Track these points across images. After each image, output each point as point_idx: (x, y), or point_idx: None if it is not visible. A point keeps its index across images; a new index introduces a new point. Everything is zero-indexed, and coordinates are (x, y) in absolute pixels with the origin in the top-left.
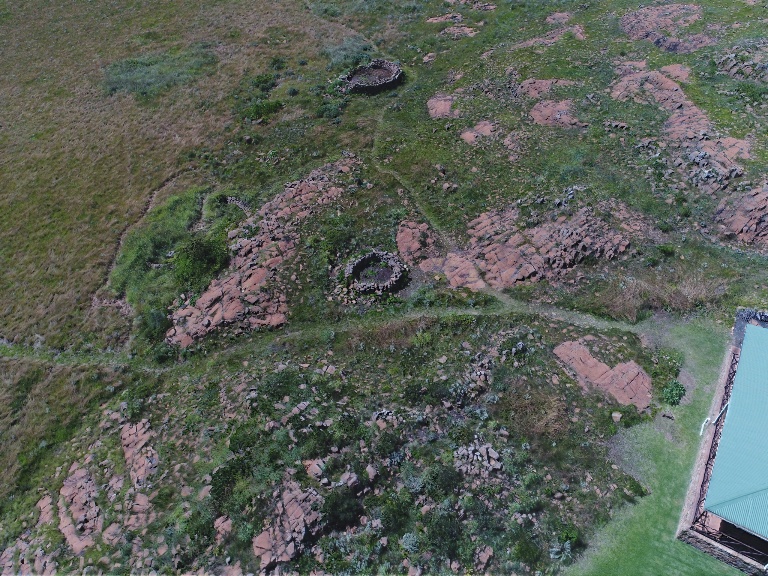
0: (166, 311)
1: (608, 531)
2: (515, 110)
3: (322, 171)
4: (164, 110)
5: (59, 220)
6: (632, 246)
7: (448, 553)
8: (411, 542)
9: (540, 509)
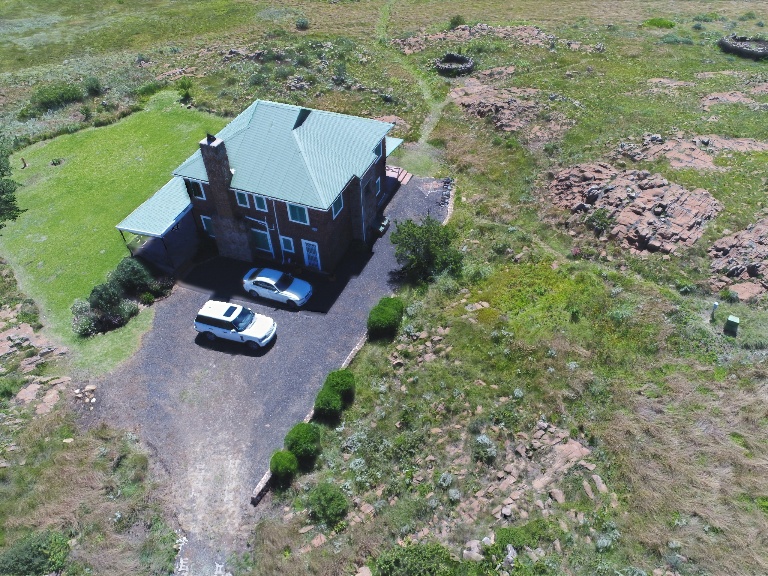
0: None
1: None
2: (721, 88)
3: (568, 41)
4: (636, 1)
5: (491, 6)
6: (514, 134)
7: None
8: (252, 74)
9: None
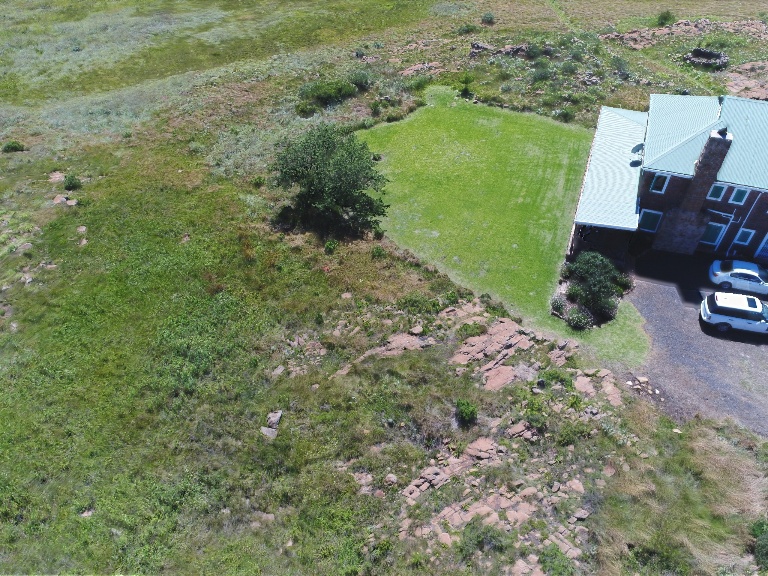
0: (618, 31)
1: (580, 128)
2: None
3: None
4: None
5: (655, 1)
6: None
7: (533, 82)
8: (531, 69)
9: (576, 104)
